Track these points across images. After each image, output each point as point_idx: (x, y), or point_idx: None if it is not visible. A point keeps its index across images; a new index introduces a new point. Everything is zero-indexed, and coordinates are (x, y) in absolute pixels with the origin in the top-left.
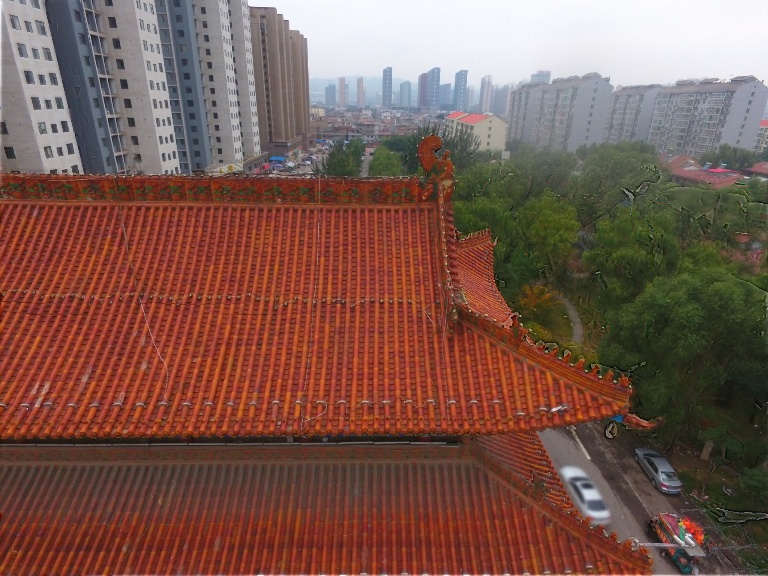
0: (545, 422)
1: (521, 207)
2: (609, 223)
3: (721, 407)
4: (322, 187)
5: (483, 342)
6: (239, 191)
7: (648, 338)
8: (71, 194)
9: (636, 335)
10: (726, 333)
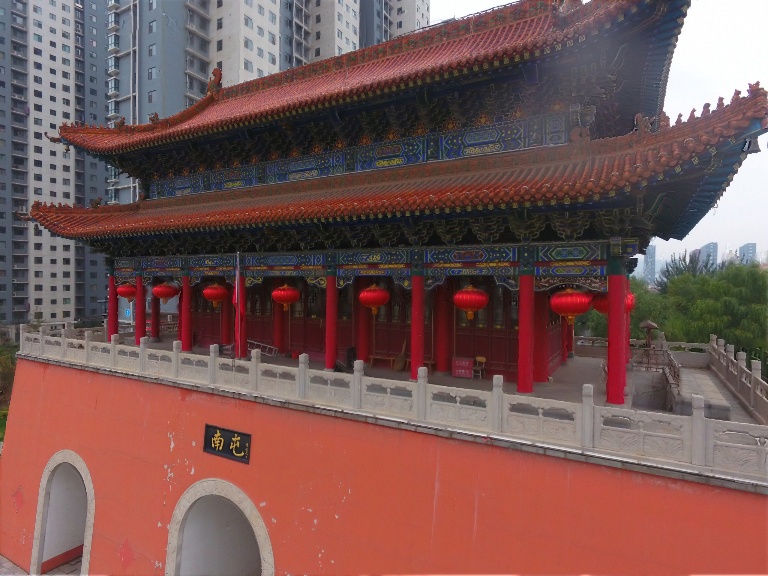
0: None
1: None
2: None
3: None
4: (475, 20)
5: None
6: (419, 40)
7: None
8: (326, 70)
9: None
10: None
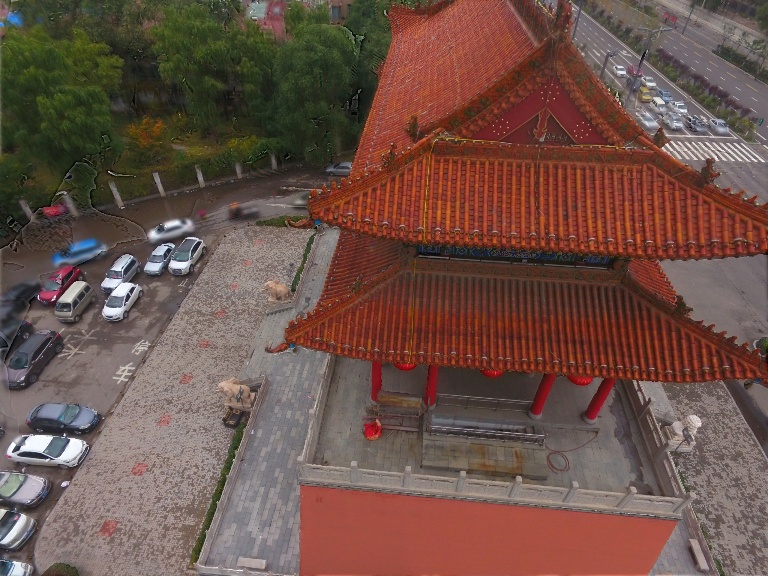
0: None
1: (57, 42)
2: (164, 28)
3: None
4: None
5: None
6: None
7: (322, 86)
8: None
9: (314, 89)
10: (347, 61)
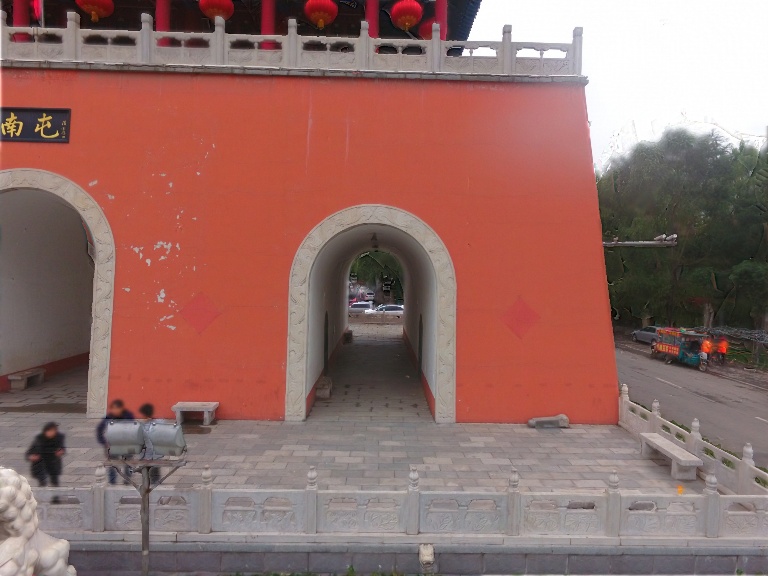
0: None
1: None
2: None
3: (706, 266)
4: None
5: None
6: None
7: (617, 190)
8: None
9: (606, 194)
10: (685, 164)
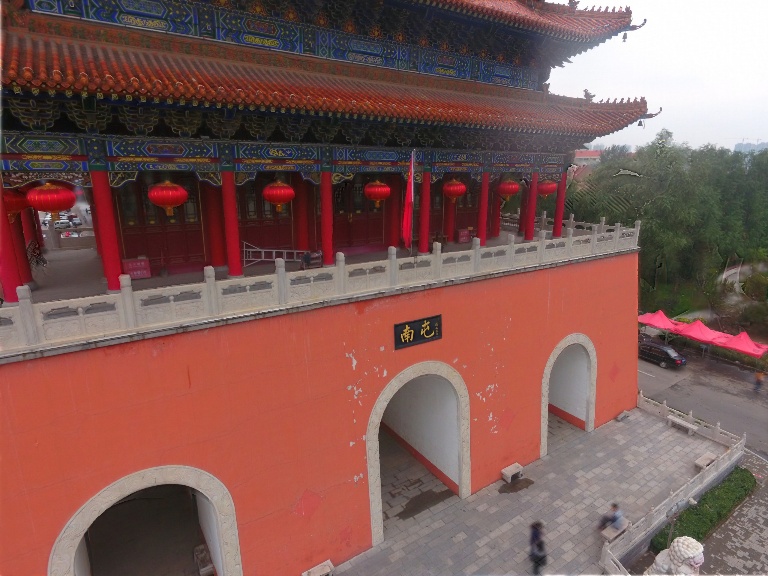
0: (605, 30)
1: None
2: None
3: None
4: None
5: (554, 17)
6: None
7: None
8: None
9: None
10: None
